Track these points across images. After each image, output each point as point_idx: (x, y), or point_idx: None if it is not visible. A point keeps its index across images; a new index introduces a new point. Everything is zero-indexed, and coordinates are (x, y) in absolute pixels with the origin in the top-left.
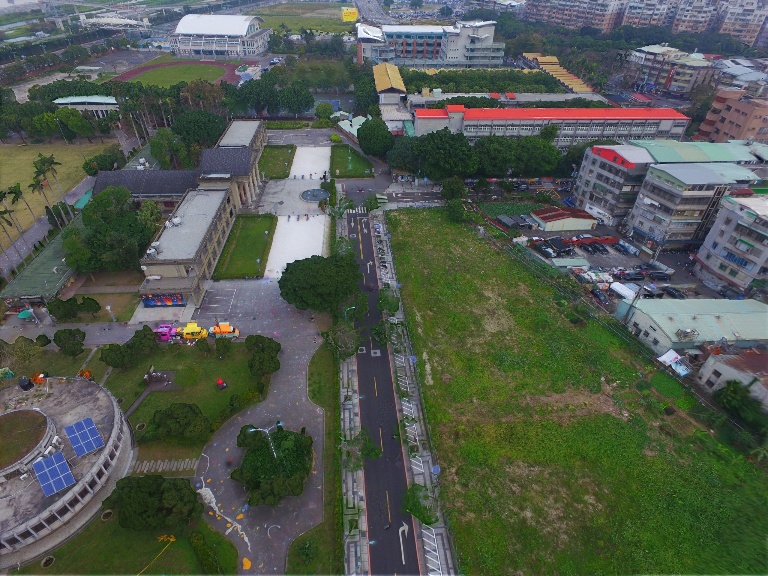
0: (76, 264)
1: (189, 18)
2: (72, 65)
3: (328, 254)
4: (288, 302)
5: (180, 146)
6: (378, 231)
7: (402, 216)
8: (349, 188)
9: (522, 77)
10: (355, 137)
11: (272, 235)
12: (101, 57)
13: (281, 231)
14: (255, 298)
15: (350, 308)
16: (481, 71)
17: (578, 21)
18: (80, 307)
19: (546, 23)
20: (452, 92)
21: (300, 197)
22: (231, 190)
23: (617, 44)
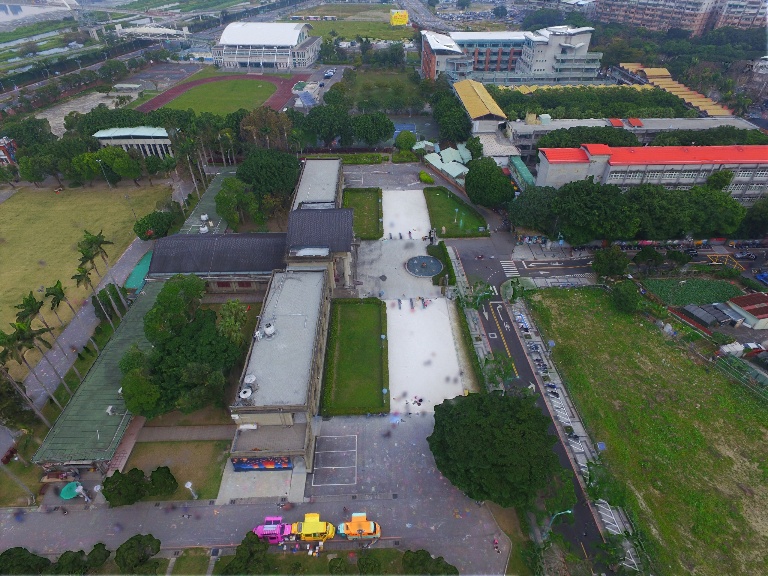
0: (140, 408)
1: (234, 27)
2: (109, 82)
3: (469, 369)
4: (453, 483)
5: (250, 198)
6: (526, 329)
7: (548, 301)
8: (463, 254)
9: (638, 96)
10: (451, 177)
11: (386, 335)
12: (139, 72)
13: (394, 326)
14: (387, 454)
15: (563, 512)
16: (586, 89)
17: (662, 22)
18: (149, 488)
19: (623, 24)
20: (561, 118)
21: (406, 269)
22: (328, 270)
23: (721, 49)
